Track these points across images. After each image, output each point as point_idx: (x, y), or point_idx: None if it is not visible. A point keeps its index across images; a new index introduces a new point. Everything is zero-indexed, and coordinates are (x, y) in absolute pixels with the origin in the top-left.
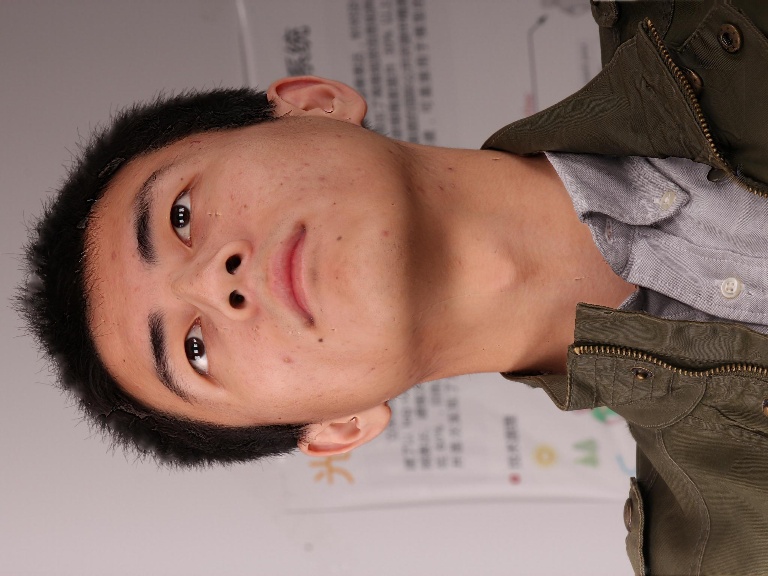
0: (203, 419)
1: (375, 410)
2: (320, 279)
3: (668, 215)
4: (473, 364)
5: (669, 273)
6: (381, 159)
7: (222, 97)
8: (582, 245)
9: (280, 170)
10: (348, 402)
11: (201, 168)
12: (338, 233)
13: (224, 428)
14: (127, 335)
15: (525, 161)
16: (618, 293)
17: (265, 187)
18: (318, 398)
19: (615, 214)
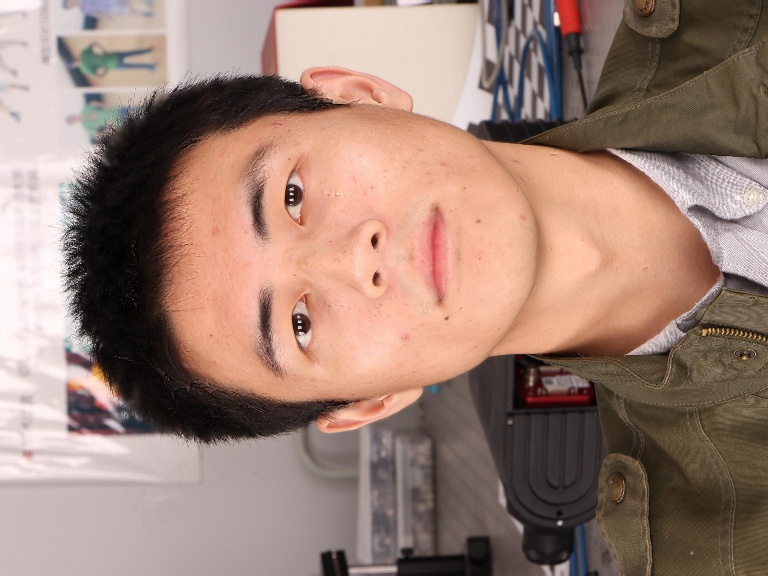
0: (266, 394)
1: None
2: (463, 259)
3: (756, 211)
4: (518, 345)
5: (761, 264)
6: (483, 148)
7: (263, 83)
8: (650, 236)
9: (398, 154)
10: (432, 379)
11: (305, 149)
12: (476, 216)
13: (279, 403)
14: (227, 310)
15: (582, 157)
16: (674, 282)
17: (389, 170)
18: (411, 374)
19: (714, 208)
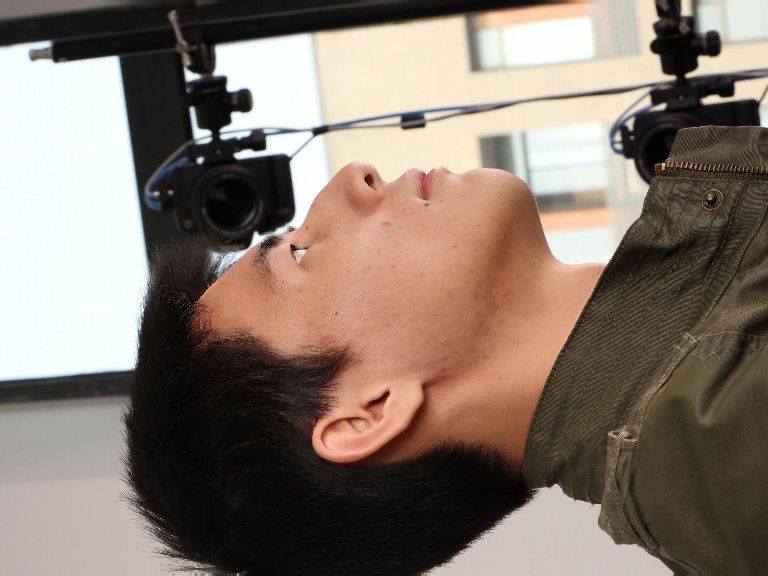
0: (258, 336)
1: (412, 385)
2: None
3: None
4: (525, 358)
5: None
6: None
7: None
8: None
9: None
10: (413, 287)
11: None
12: None
13: (270, 353)
14: None
15: None
16: None
17: None
18: (390, 270)
19: None
